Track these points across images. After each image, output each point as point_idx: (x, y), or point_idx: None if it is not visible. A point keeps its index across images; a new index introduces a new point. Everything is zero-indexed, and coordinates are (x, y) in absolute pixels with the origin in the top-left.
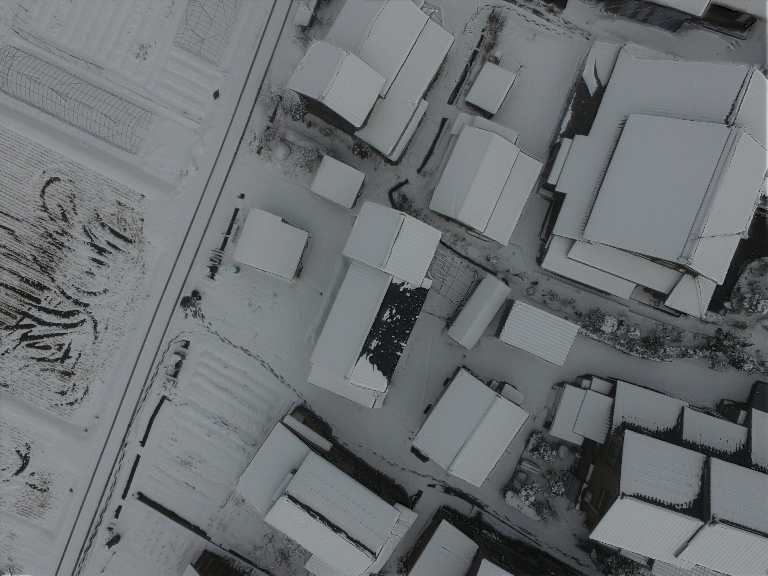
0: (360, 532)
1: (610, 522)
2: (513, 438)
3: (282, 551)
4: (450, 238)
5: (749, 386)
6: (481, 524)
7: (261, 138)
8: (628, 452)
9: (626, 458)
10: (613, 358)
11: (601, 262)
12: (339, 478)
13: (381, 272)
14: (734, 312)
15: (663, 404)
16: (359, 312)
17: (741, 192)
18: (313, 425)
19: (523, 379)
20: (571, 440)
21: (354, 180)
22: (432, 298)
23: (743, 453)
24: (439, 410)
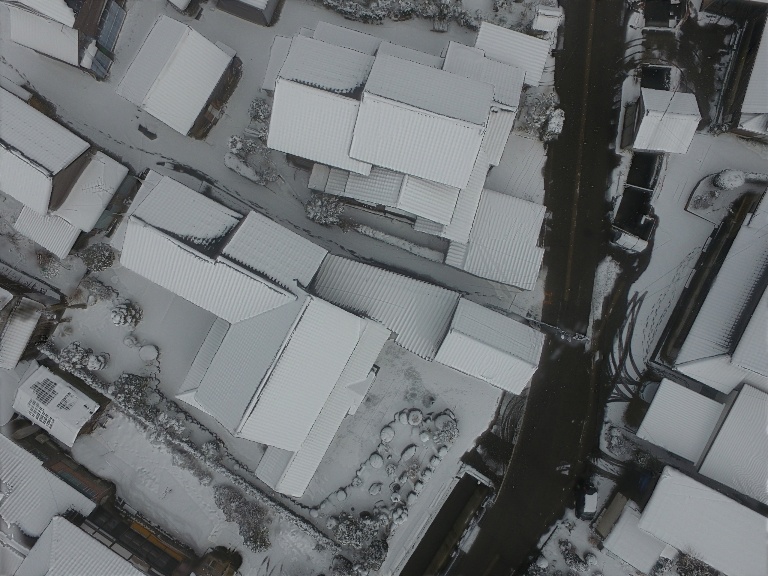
0: (39, 154)
1: (279, 120)
2: (217, 84)
3: None
4: None
5: None
6: None
7: None
8: (296, 50)
9: (292, 53)
10: (335, 24)
11: None
12: (23, 109)
13: None
14: None
15: (363, 40)
16: None
17: None
18: (35, 103)
19: (246, 48)
20: None
21: None
22: None
23: None
24: (139, 56)
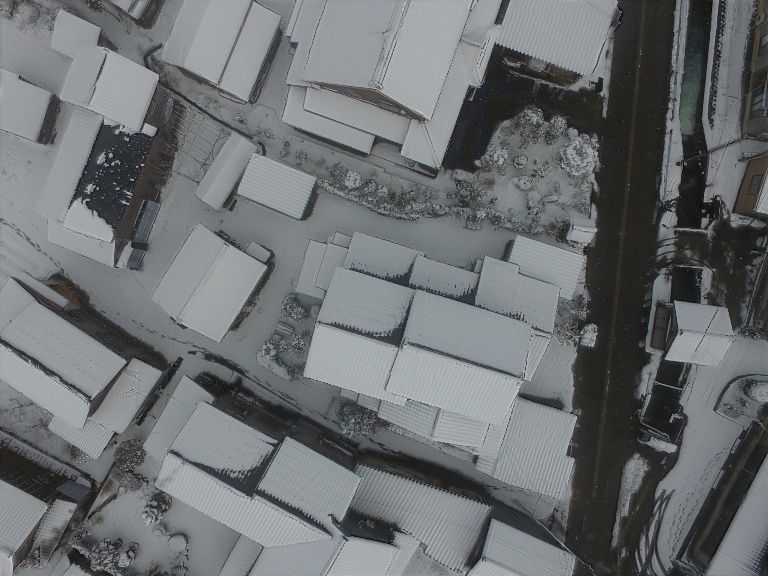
0: (77, 377)
1: (316, 356)
2: (251, 292)
3: (42, 421)
4: (204, 101)
5: (503, 245)
6: (240, 389)
7: (9, 1)
8: (334, 286)
9: (330, 291)
10: (368, 219)
11: (335, 112)
12: (61, 327)
13: (94, 114)
14: (484, 169)
15: (398, 253)
16: (75, 156)
17: (440, 21)
18: (69, 293)
19: (279, 242)
20: (314, 295)
21: (90, 35)
22: (188, 163)
23: (470, 296)
24: (175, 264)
